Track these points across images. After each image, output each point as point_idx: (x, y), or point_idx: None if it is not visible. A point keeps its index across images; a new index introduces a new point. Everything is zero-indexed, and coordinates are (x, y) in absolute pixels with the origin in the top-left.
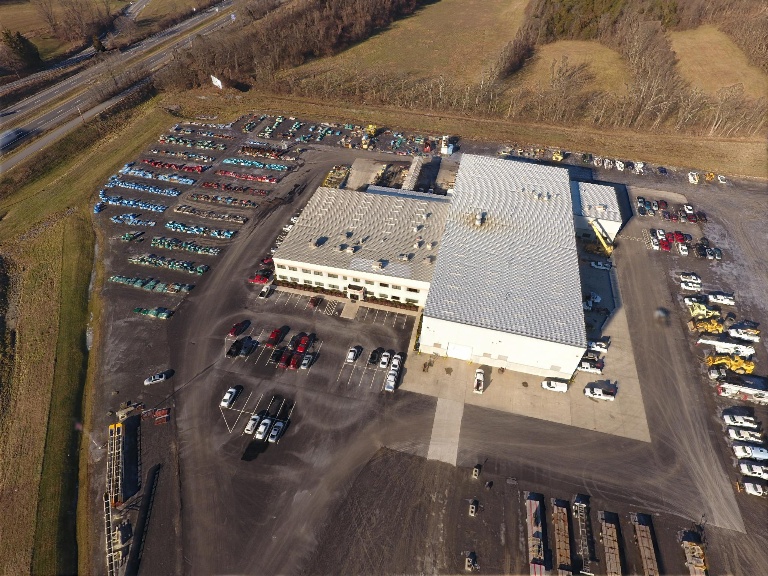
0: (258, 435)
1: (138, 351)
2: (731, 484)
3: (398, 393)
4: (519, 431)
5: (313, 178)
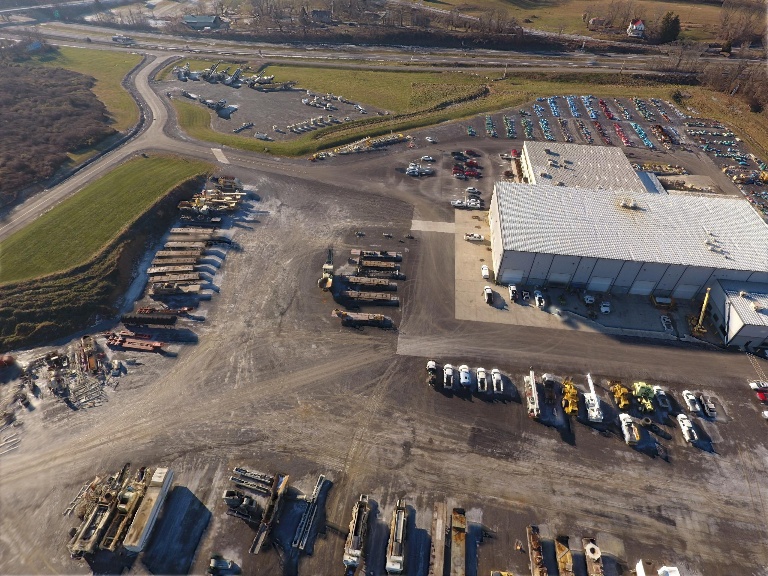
0: (408, 168)
1: (444, 133)
2: (433, 357)
3: (452, 208)
4: (442, 255)
5: (650, 159)
